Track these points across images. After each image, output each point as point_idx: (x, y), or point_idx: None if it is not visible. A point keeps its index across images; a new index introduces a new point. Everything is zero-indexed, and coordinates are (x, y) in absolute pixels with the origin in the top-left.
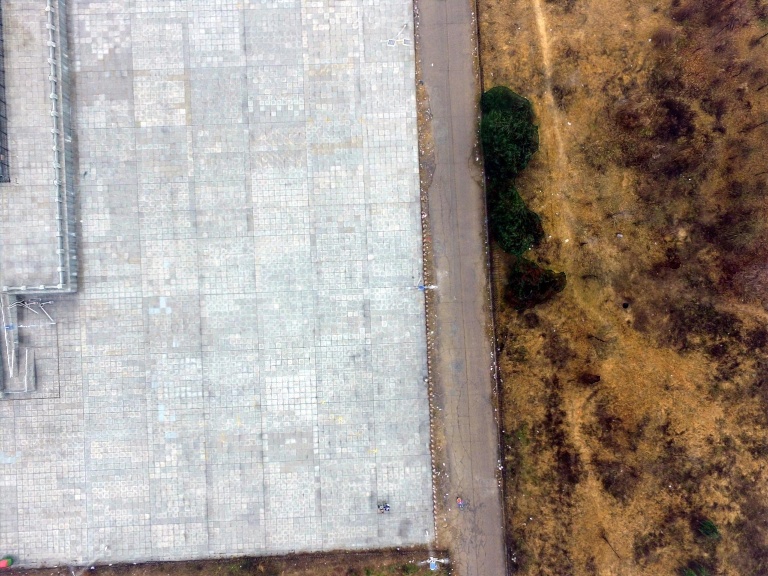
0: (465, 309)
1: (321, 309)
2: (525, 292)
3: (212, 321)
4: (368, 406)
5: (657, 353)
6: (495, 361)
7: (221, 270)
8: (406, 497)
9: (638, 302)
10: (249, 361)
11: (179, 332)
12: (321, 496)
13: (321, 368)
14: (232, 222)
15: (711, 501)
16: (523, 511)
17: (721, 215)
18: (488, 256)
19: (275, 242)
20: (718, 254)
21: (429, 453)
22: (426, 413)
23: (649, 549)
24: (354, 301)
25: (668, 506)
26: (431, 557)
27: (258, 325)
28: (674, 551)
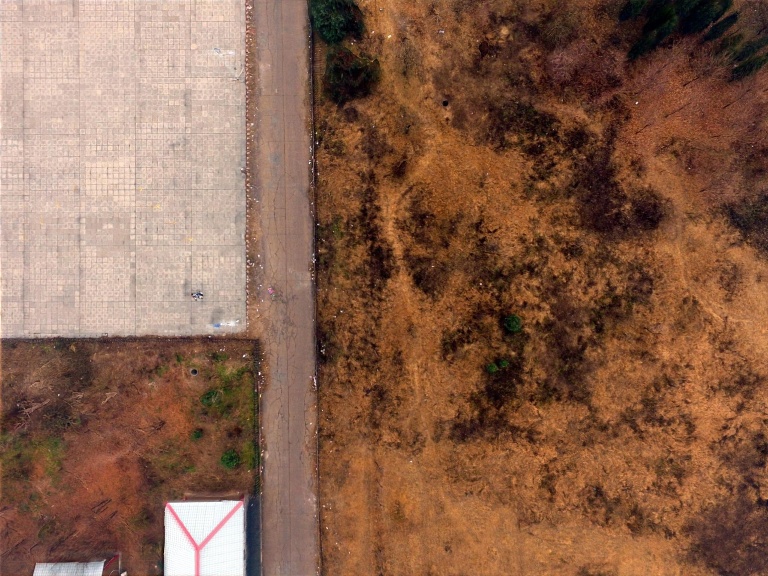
0: (286, 102)
1: (143, 97)
2: (337, 77)
3: (35, 104)
4: (186, 195)
5: (474, 150)
6: (313, 155)
7: (45, 54)
8: (220, 286)
9: (457, 99)
10: (70, 145)
11: (2, 114)
12: (136, 282)
13: (141, 155)
14: (58, 7)
15: (521, 300)
16: (334, 304)
17: (544, 14)
18: (311, 50)
19: (100, 28)
20: (540, 54)
21: (244, 244)
22: (243, 204)
23: (457, 345)
24: (176, 90)
25: (477, 303)
26: (221, 323)
27: (80, 110)
28: (481, 348)
